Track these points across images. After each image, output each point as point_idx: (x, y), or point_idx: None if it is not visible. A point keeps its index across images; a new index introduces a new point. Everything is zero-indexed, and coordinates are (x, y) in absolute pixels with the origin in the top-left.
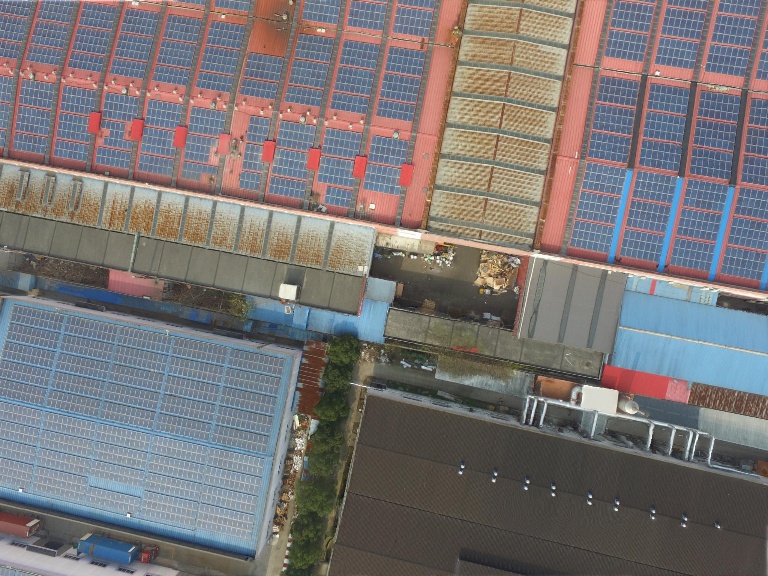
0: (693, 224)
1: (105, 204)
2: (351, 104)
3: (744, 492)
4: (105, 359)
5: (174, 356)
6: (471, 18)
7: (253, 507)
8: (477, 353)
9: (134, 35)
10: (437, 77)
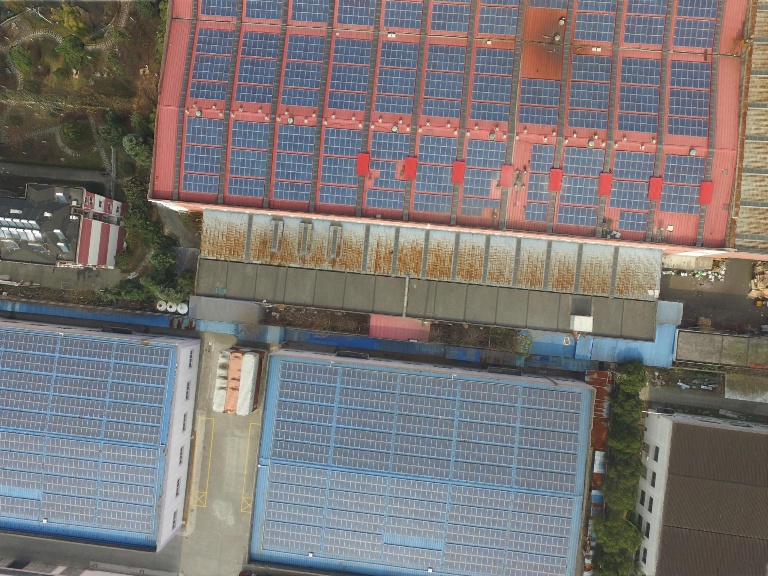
0: None
1: (368, 248)
2: (640, 124)
3: None
4: (388, 410)
5: (462, 400)
6: (756, 25)
7: (565, 550)
8: None
9: (395, 69)
10: (726, 89)
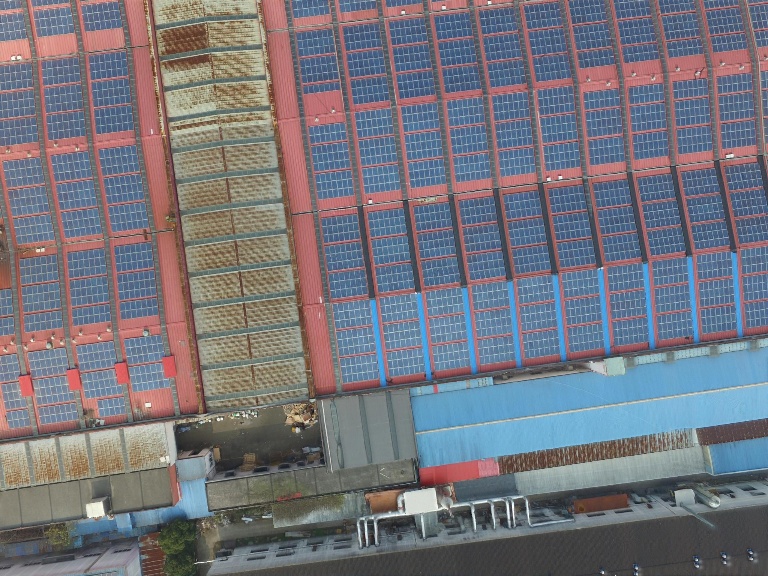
0: (443, 330)
1: None
2: (93, 315)
3: (564, 540)
4: None
5: None
6: (183, 198)
7: None
8: (300, 497)
9: None
10: (169, 263)
